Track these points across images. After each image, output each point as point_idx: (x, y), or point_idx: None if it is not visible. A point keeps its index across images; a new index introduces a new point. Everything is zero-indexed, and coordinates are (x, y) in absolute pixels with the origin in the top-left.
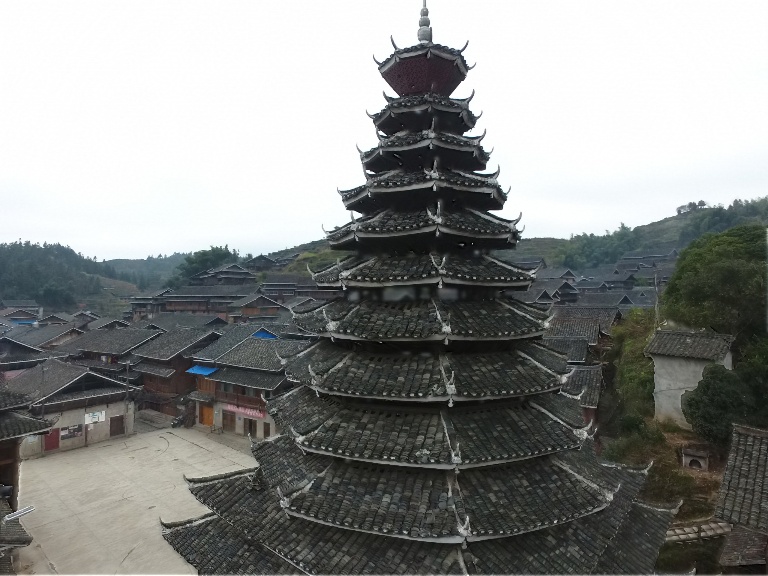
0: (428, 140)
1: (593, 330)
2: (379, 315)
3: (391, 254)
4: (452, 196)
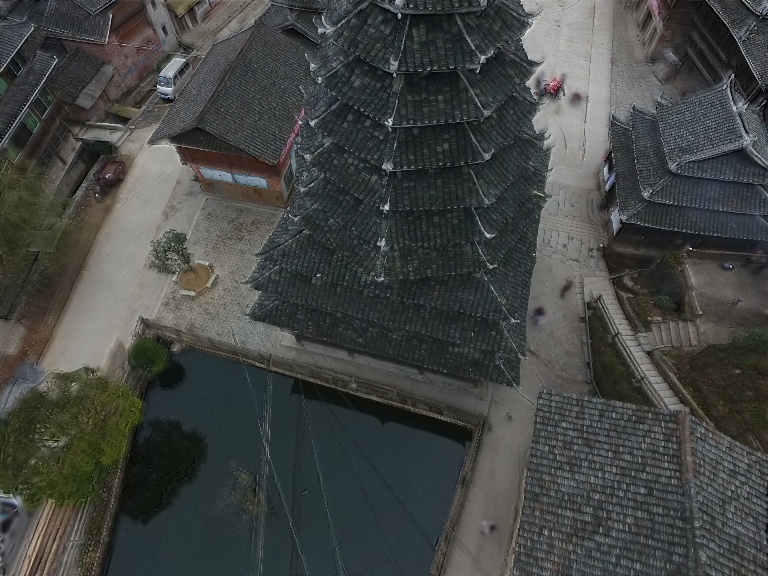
0: None
1: None
2: None
3: None
4: None
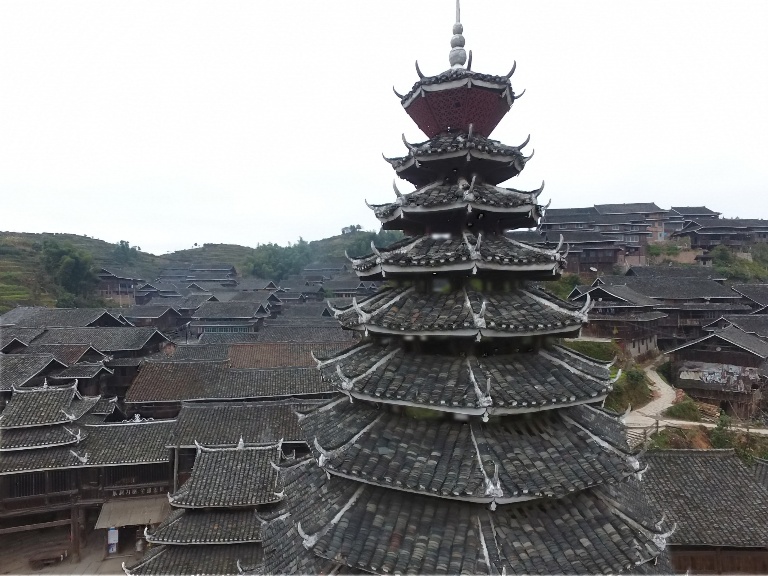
0: (531, 206)
1: None
2: (523, 450)
3: (487, 352)
4: (540, 277)
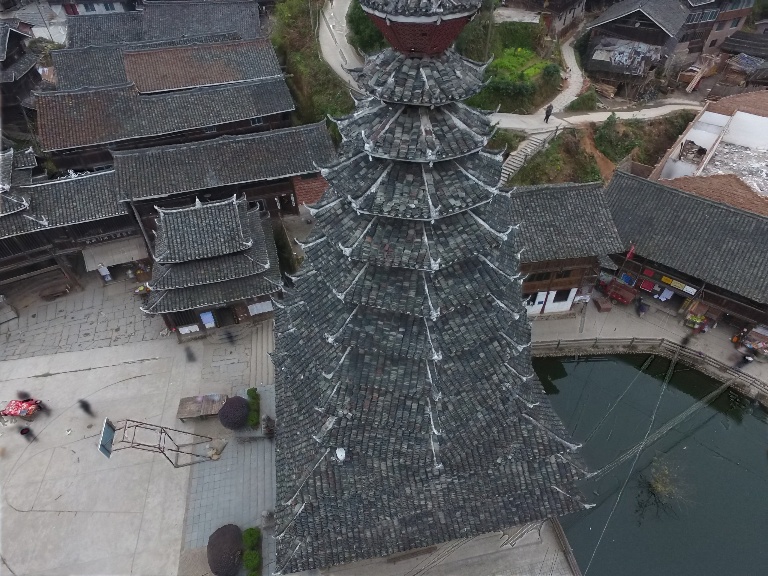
0: None
1: (271, 56)
2: (454, 320)
3: None
4: None
